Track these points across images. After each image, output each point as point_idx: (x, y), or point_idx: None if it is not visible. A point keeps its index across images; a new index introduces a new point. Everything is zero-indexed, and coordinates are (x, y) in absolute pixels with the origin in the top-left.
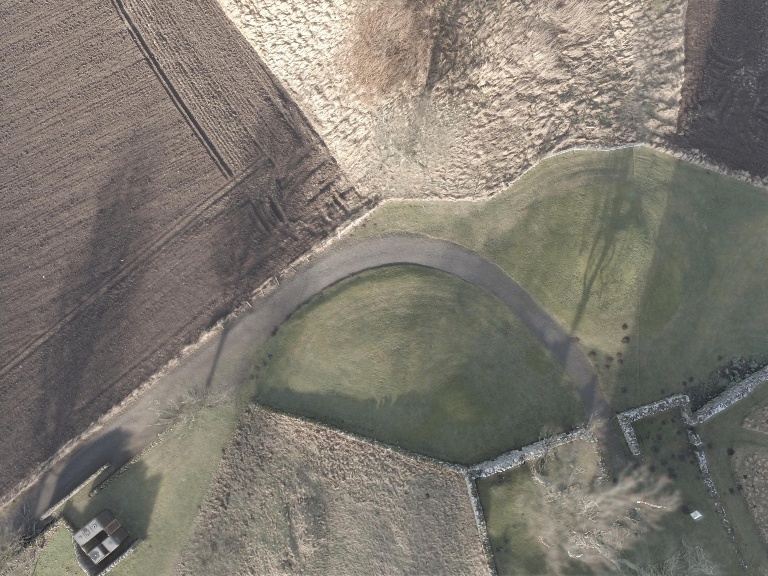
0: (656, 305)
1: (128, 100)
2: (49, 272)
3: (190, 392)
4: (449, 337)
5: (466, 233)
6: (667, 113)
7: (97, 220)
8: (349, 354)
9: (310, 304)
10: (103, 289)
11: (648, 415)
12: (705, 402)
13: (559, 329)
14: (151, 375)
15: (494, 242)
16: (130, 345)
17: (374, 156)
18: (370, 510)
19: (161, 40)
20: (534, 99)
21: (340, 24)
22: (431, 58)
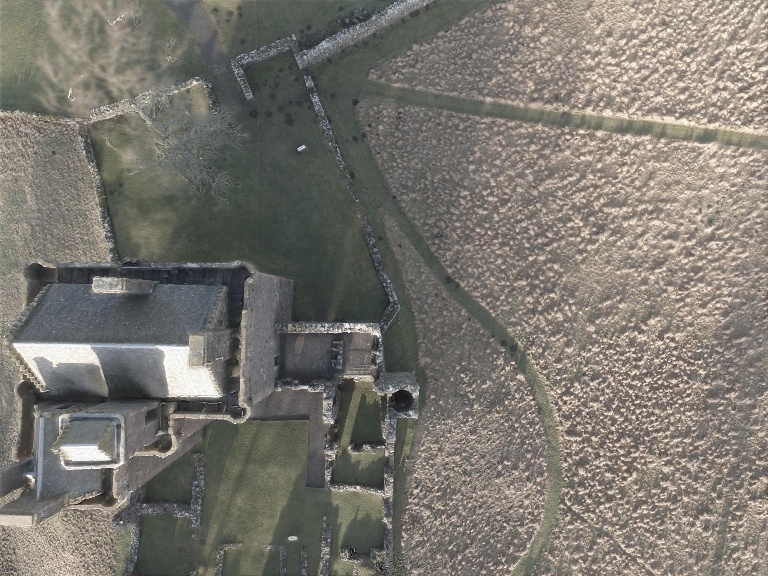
0: None
1: None
2: None
3: None
4: (82, 8)
5: None
6: None
7: None
8: None
9: None
10: None
11: None
12: None
13: None
14: None
15: None
16: None
17: None
18: (11, 179)
19: None
20: None
21: None
22: None
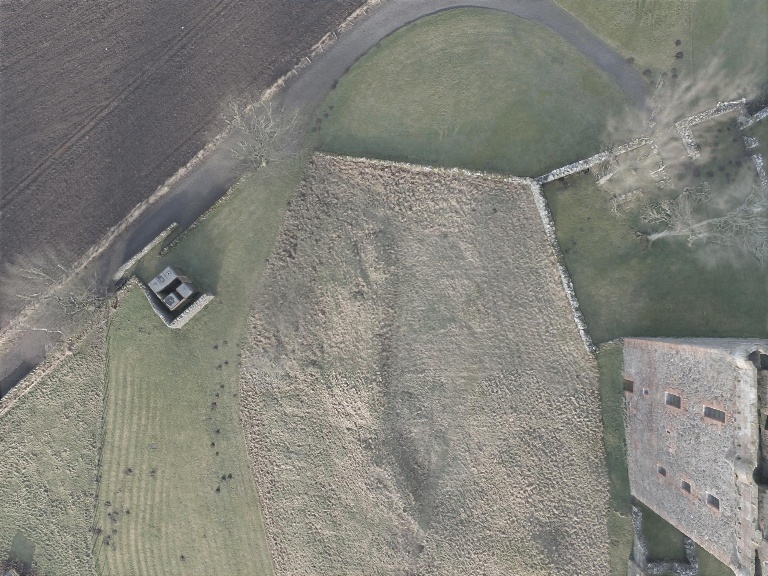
0: (708, 19)
1: None
2: (111, 44)
3: None
4: (507, 66)
5: None
6: None
7: None
8: (410, 94)
9: (368, 54)
10: (165, 57)
11: None
12: (759, 110)
13: (614, 52)
14: (215, 136)
15: None
16: (193, 109)
17: None
18: (438, 235)
19: None
20: None
21: None
22: None
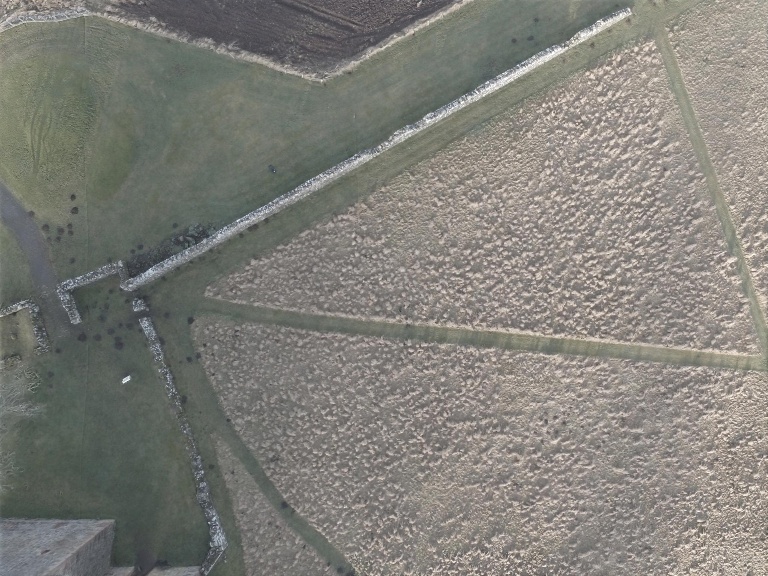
0: (101, 173)
1: None
2: None
3: None
4: None
5: None
6: None
7: None
8: None
9: None
10: None
11: None
12: None
13: (18, 205)
14: None
15: None
16: None
17: None
18: None
19: None
20: None
21: None
22: None
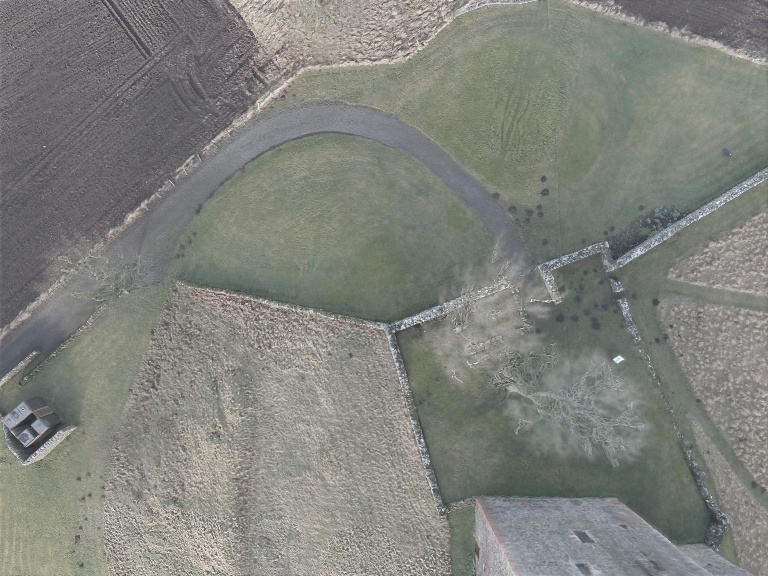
0: (574, 155)
1: None
2: None
3: None
4: (369, 200)
5: (384, 97)
6: None
7: (18, 107)
8: (272, 224)
9: (233, 179)
10: (27, 177)
11: (569, 264)
12: (627, 251)
13: (479, 186)
14: (78, 260)
15: (413, 104)
16: (56, 232)
17: (290, 25)
18: (296, 376)
19: None
20: None
21: None
22: None
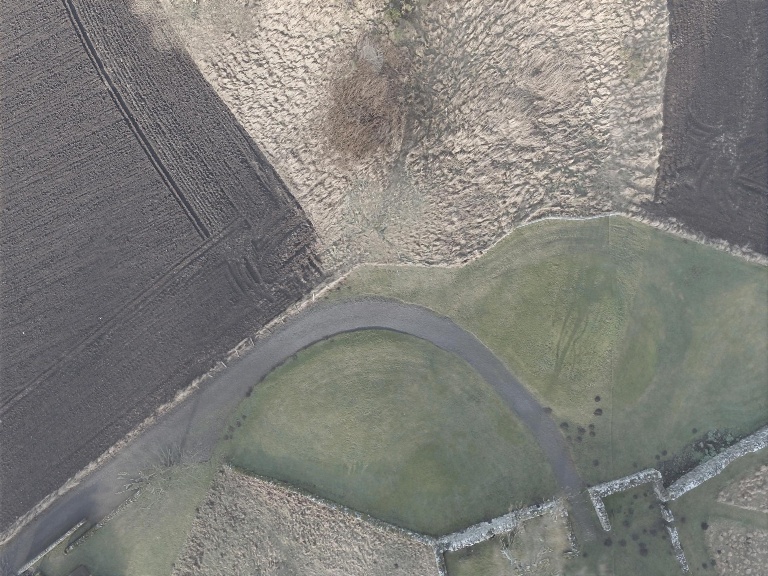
0: (630, 378)
1: (107, 160)
2: (29, 328)
3: (165, 450)
4: (421, 405)
5: (440, 299)
6: (644, 182)
7: (76, 278)
8: (322, 418)
9: (284, 366)
10: (81, 346)
11: (620, 490)
12: (678, 477)
13: (532, 399)
14: (127, 433)
15: (468, 309)
16: (107, 402)
17: (349, 220)
18: None
19: (140, 101)
20: (509, 166)
21: (315, 90)
22: (405, 125)
